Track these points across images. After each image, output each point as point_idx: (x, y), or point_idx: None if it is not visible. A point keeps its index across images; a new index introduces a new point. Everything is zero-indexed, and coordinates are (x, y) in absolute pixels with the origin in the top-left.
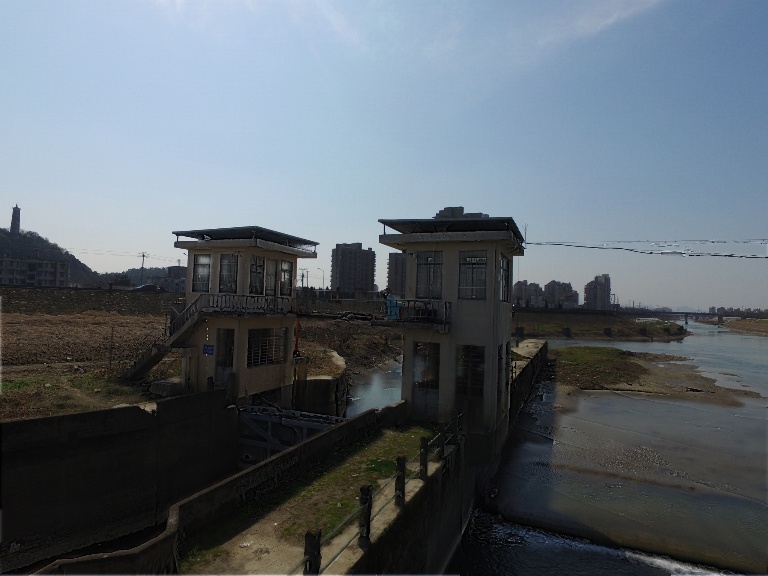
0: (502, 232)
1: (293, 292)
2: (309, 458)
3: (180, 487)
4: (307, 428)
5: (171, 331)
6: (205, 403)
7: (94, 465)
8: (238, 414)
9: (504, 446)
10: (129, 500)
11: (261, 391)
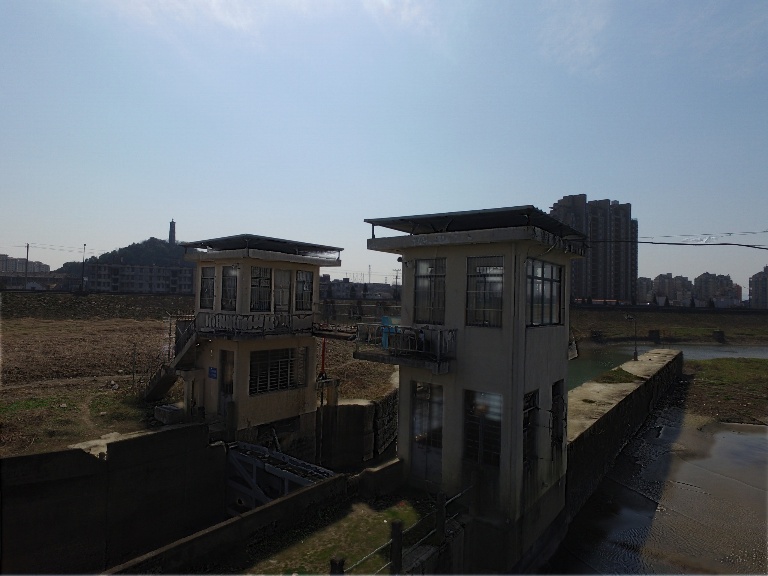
0: (520, 229)
1: (314, 306)
2: (188, 564)
3: (141, 540)
4: (289, 480)
5: (176, 352)
6: (177, 442)
7: (26, 516)
8: (226, 452)
9: (581, 508)
10: (70, 557)
11: (271, 421)
